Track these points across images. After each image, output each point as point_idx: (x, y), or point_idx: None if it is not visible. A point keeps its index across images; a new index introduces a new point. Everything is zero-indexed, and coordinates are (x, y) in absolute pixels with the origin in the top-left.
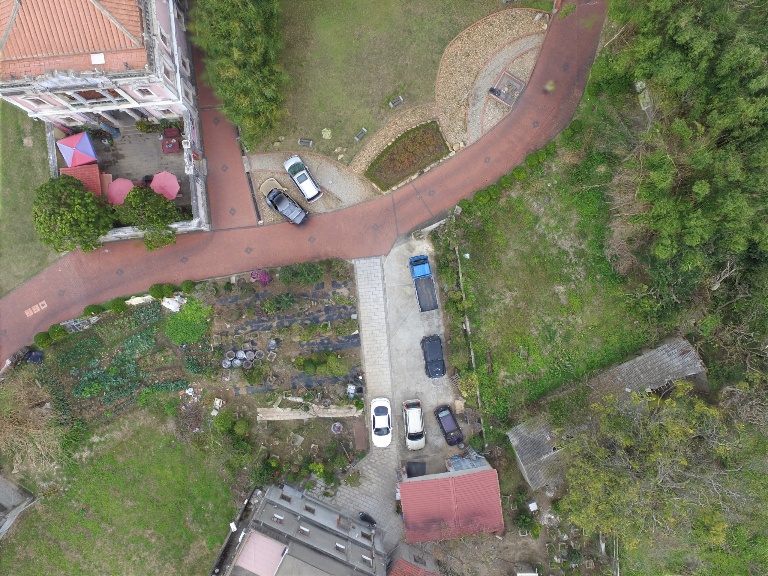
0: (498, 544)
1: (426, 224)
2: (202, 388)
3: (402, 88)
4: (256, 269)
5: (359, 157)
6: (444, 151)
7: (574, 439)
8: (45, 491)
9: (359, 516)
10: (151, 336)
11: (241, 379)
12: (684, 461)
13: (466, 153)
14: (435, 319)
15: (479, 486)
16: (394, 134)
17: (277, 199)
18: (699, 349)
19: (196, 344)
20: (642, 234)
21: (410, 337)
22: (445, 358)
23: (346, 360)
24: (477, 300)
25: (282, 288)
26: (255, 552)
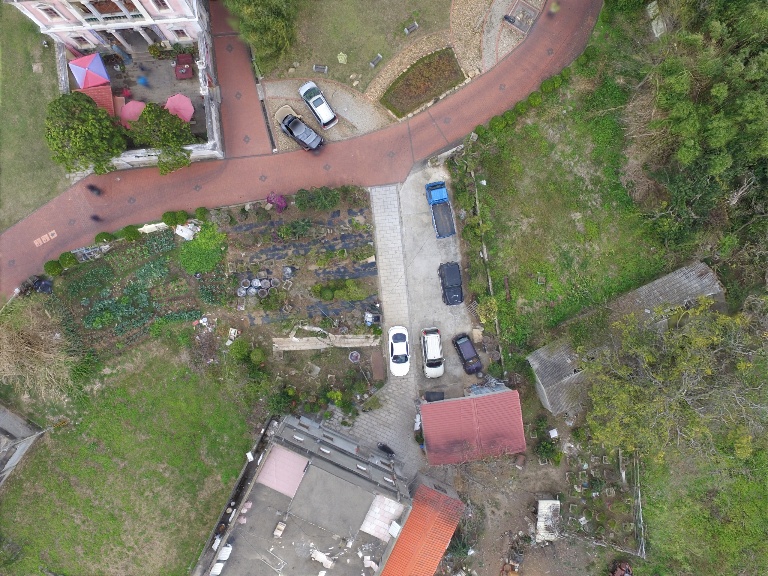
0: (518, 474)
1: (442, 151)
2: (216, 318)
3: (417, 15)
4: (272, 192)
5: (374, 84)
6: (459, 78)
7: None
8: None
9: (377, 446)
10: (164, 265)
11: (256, 309)
12: (708, 370)
13: (481, 80)
14: (452, 247)
15: (501, 407)
16: (409, 61)
17: (293, 124)
18: (717, 270)
19: (210, 274)
20: (658, 157)
21: (427, 265)
22: (462, 286)
23: (364, 285)
24: (494, 227)
25: (297, 216)
26: (276, 469)
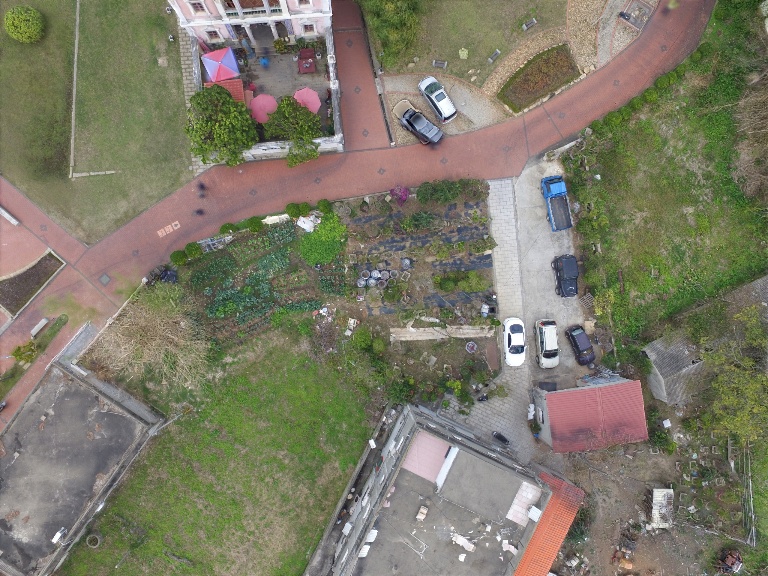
0: (628, 463)
1: (556, 146)
2: (335, 308)
3: (534, 11)
4: None
5: (491, 79)
6: (575, 74)
7: (713, 352)
8: (178, 412)
9: (493, 435)
10: (285, 256)
11: (374, 299)
12: None
13: (596, 76)
14: (565, 240)
15: (624, 396)
16: (526, 57)
17: (414, 118)
18: None
19: (329, 265)
20: None
21: (541, 258)
22: None
23: (485, 277)
24: None
25: (415, 209)
26: (418, 454)
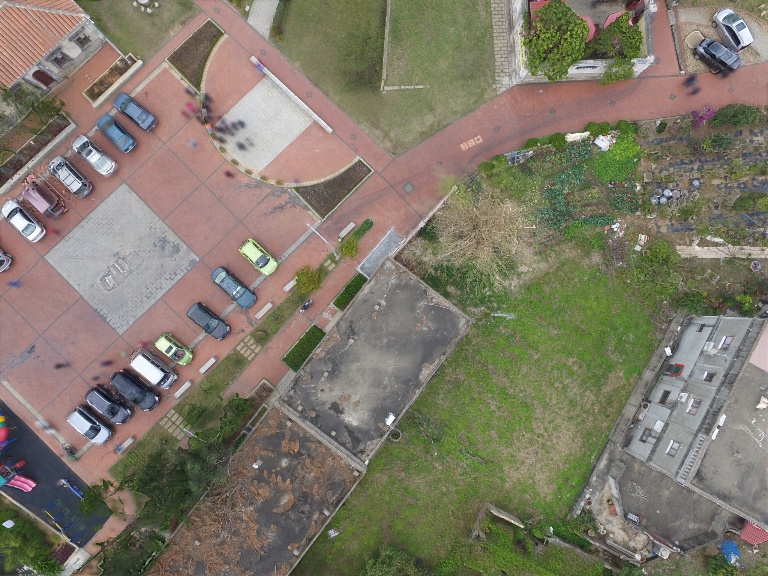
0: None
1: None
2: (626, 224)
3: None
4: None
5: None
6: None
7: None
8: (476, 316)
9: None
10: (580, 173)
11: (663, 218)
12: None
13: None
14: None
15: None
16: None
17: (713, 46)
18: None
19: (621, 183)
20: None
21: None
22: None
23: None
24: None
25: (704, 133)
26: (759, 347)
